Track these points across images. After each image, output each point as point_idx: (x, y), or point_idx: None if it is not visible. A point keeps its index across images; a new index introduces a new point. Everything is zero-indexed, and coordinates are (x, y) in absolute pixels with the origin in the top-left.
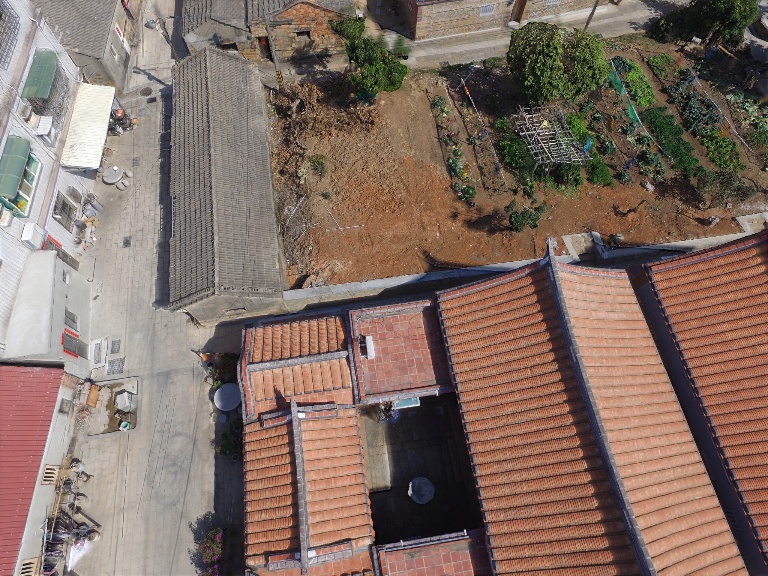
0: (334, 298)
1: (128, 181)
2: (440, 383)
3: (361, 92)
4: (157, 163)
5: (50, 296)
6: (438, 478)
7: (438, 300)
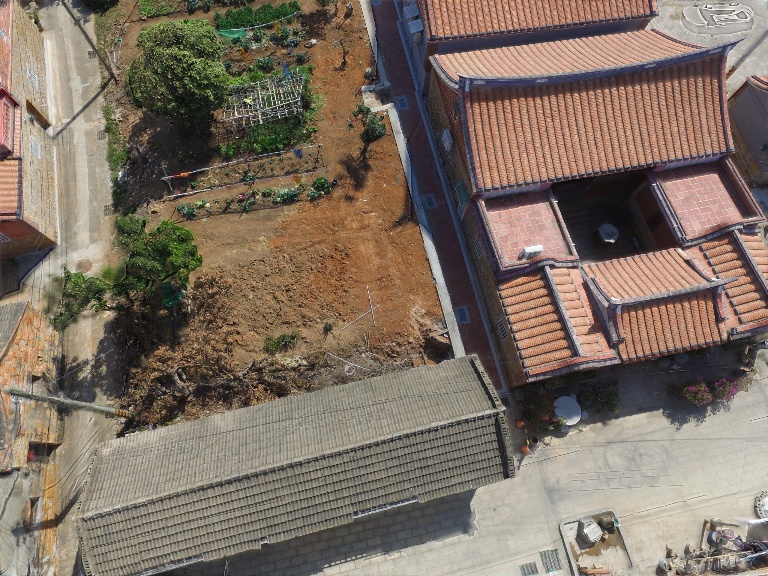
0: None
1: None
2: (547, 199)
3: None
4: None
5: None
6: (588, 227)
7: (483, 190)
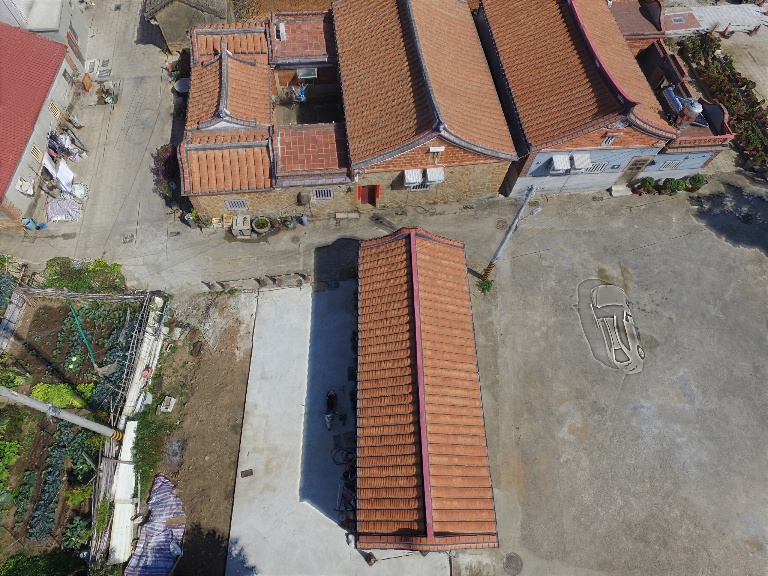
0: None
1: None
2: None
3: None
4: None
5: (60, 0)
6: None
7: (332, 5)
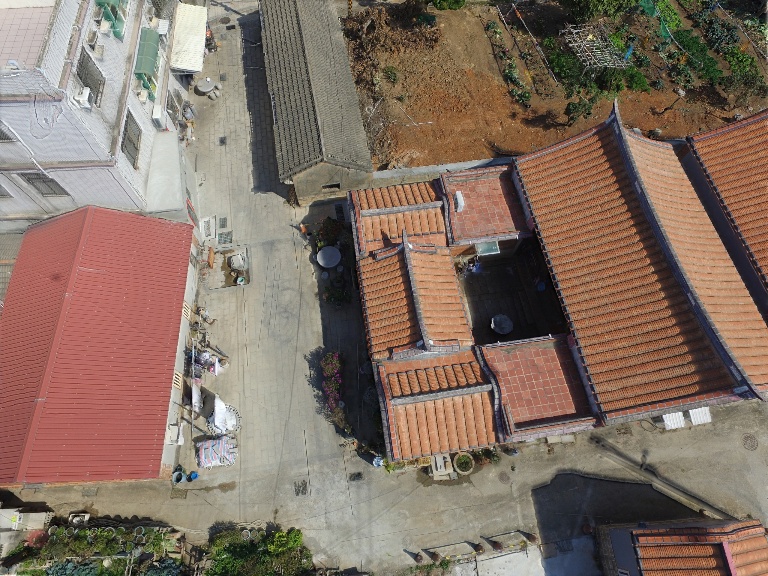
0: (414, 180)
1: (218, 93)
2: (519, 230)
3: (423, 16)
4: (242, 78)
5: (179, 165)
6: None
7: (515, 163)
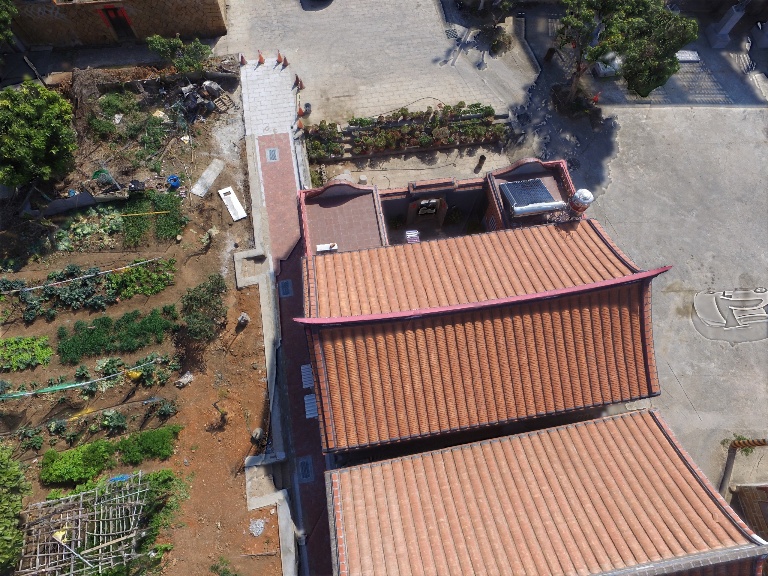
0: None
1: None
2: None
3: None
4: None
5: None
6: None
7: None
